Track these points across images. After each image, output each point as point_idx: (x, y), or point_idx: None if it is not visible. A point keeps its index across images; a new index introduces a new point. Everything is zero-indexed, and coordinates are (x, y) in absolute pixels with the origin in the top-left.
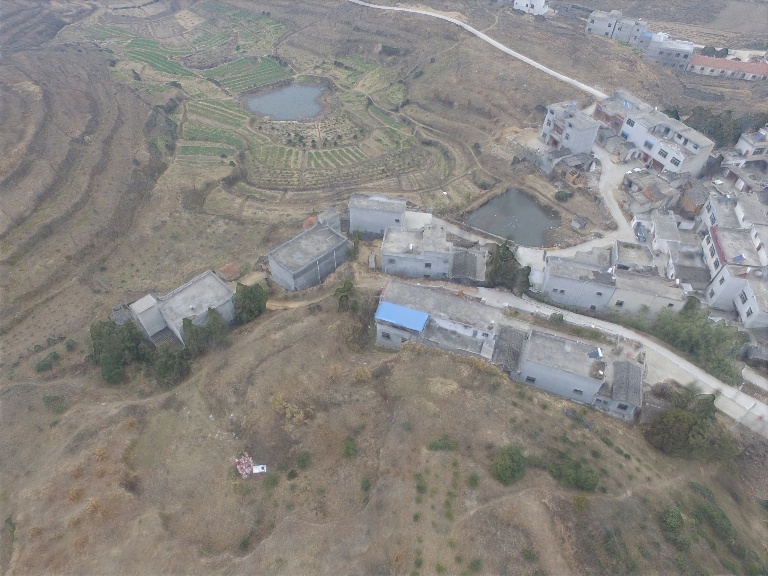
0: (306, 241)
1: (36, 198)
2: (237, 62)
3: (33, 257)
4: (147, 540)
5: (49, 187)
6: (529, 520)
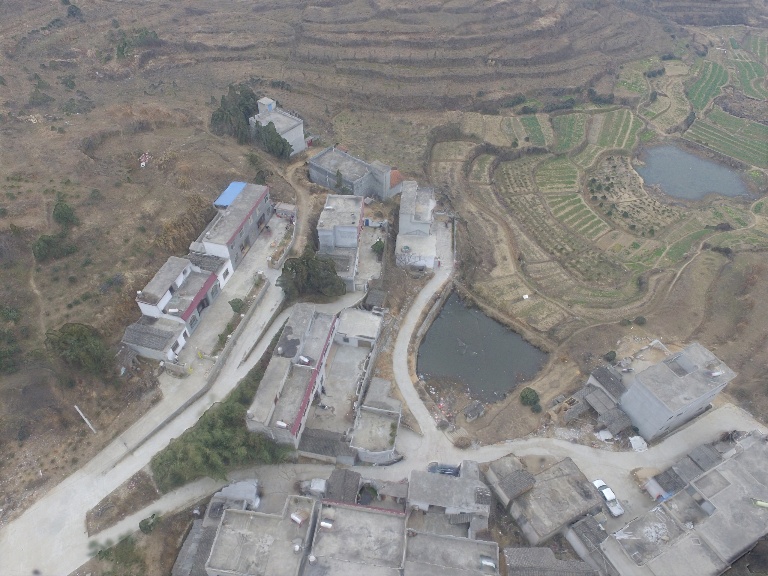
0: (351, 164)
1: (397, 59)
2: (764, 127)
3: (346, 78)
4: (105, 128)
5: (413, 61)
6: (26, 219)
